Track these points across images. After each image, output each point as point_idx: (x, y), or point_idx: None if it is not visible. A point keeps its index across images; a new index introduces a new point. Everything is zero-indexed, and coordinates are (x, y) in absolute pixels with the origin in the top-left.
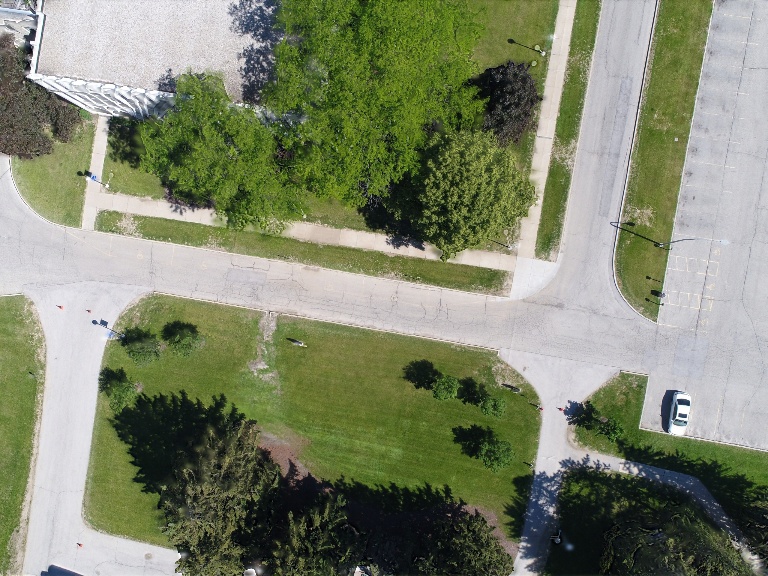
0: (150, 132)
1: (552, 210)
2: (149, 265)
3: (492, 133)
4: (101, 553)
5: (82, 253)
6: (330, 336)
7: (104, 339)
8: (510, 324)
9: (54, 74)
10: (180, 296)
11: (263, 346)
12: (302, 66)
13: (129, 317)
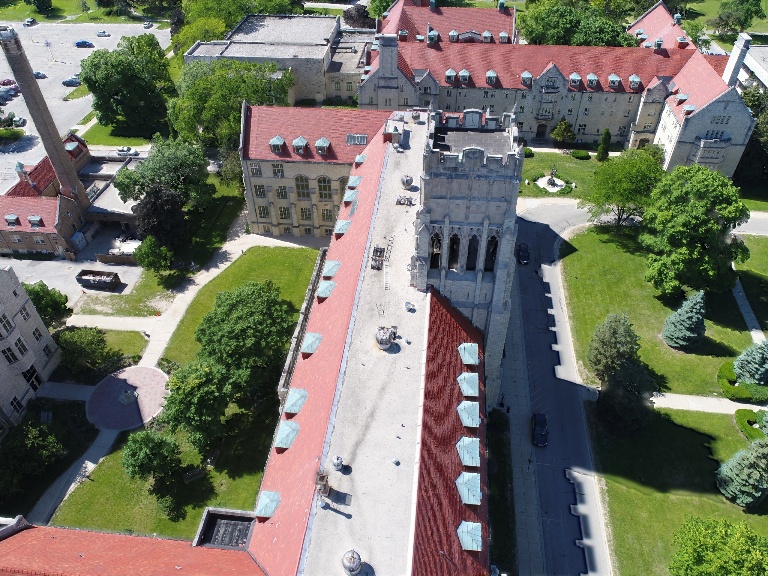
0: None
1: None
2: None
3: None
4: None
5: None
6: None
7: None
8: None
9: (331, 18)
10: None
11: None
12: None
13: None
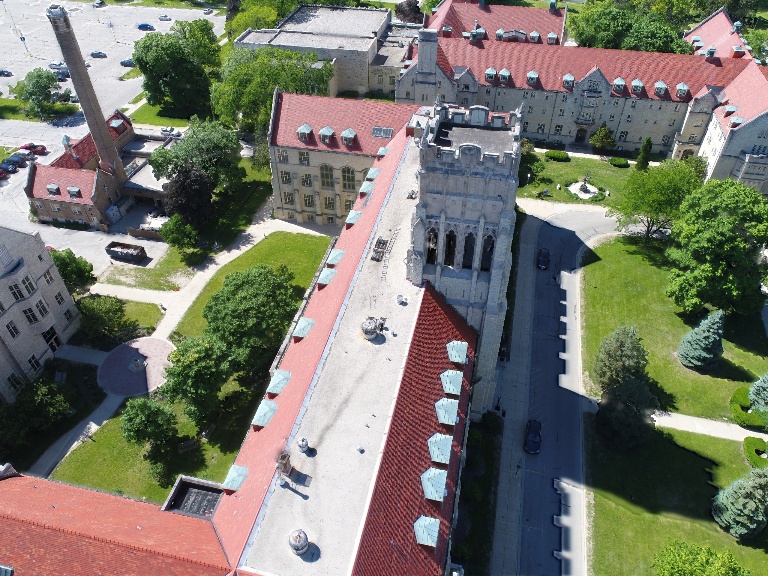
0: None
1: None
2: None
3: None
4: (396, 1)
5: None
6: None
7: None
8: None
9: None
10: None
11: None
12: None
13: None
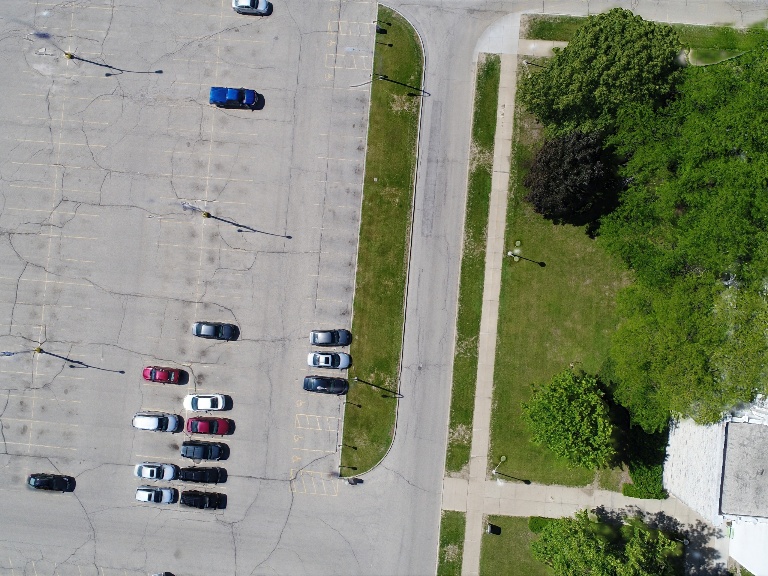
0: None
1: (488, 102)
2: None
3: None
4: None
5: None
6: None
7: None
8: None
9: None
10: None
11: None
12: None
13: None
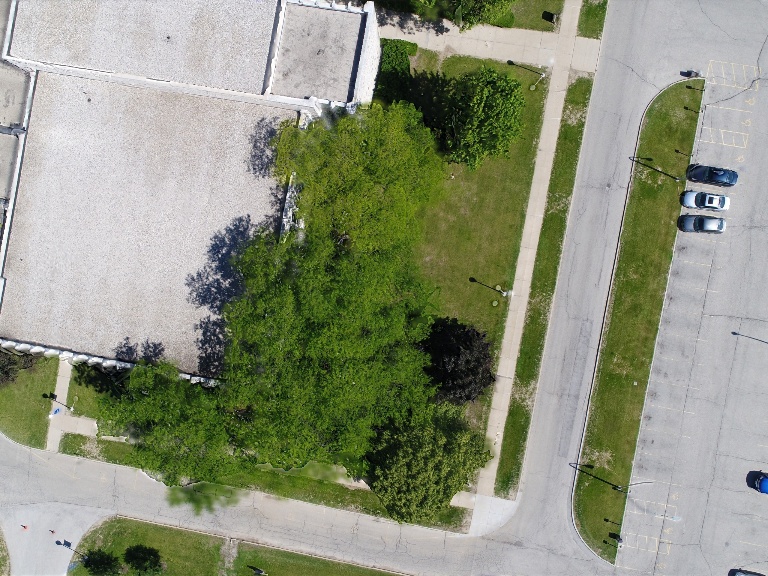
0: (106, 406)
1: (511, 449)
2: (112, 488)
3: (447, 402)
4: None
5: (46, 474)
6: (290, 565)
7: (67, 560)
8: (469, 560)
9: (14, 338)
10: (143, 520)
11: (224, 572)
12: (252, 374)
13: (92, 539)
